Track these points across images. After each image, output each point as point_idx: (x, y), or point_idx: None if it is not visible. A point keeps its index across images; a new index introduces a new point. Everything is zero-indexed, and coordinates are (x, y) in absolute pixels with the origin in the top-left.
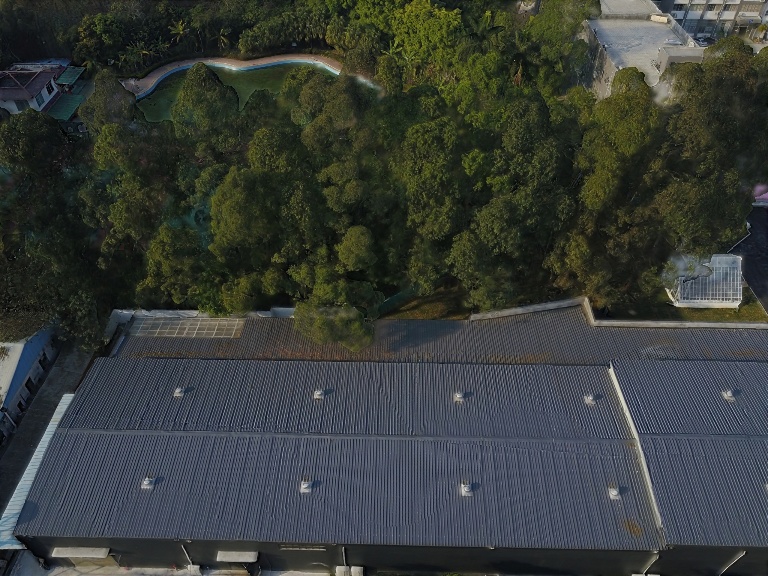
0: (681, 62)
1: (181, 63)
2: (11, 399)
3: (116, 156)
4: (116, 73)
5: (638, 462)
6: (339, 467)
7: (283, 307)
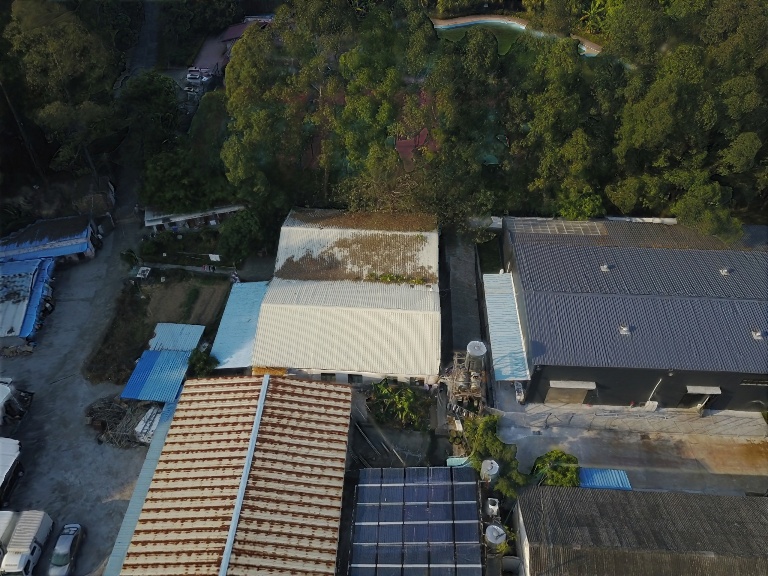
0: None
1: None
2: None
3: (571, 64)
4: None
5: None
6: None
7: (616, 217)
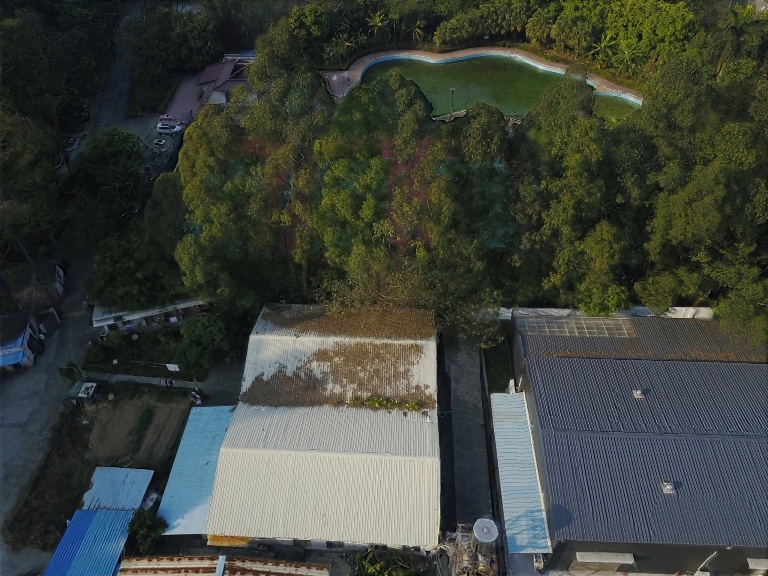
0: None
1: (377, 55)
2: None
3: (596, 151)
4: (320, 65)
5: None
6: None
7: (643, 306)
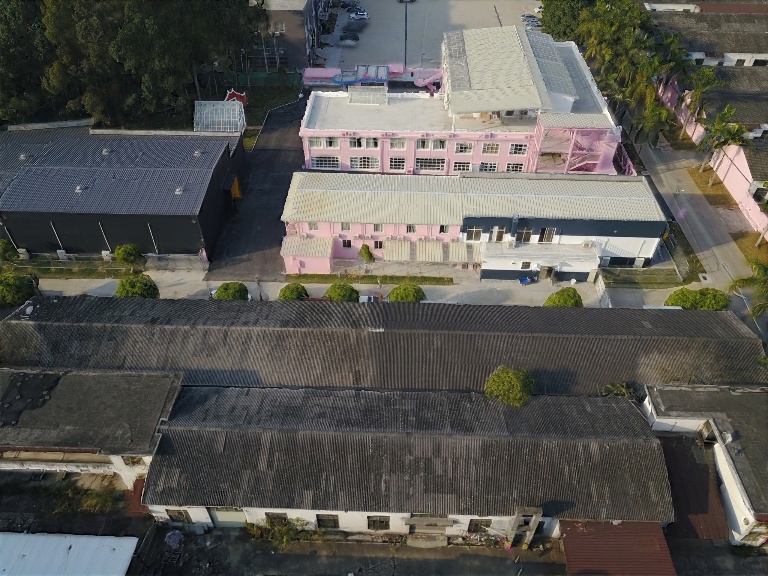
0: None
1: None
2: None
3: None
4: None
5: None
6: None
7: None
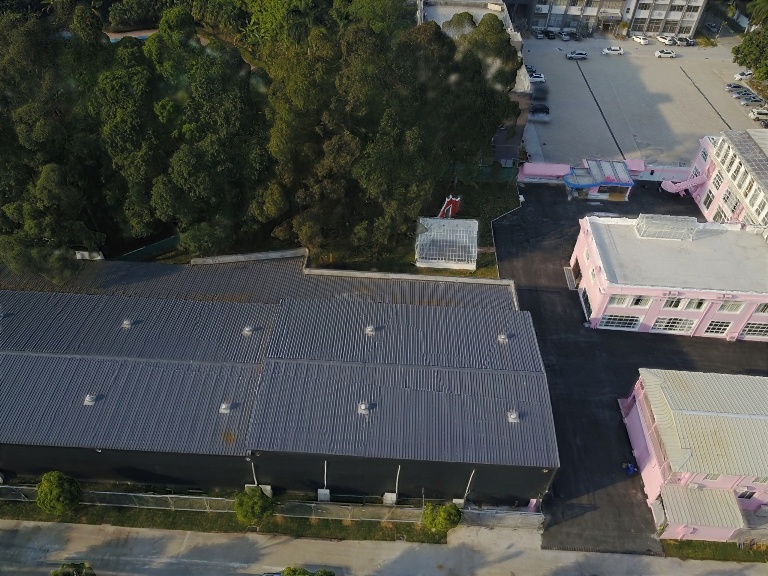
0: None
1: None
2: None
3: None
4: None
5: None
6: None
7: None
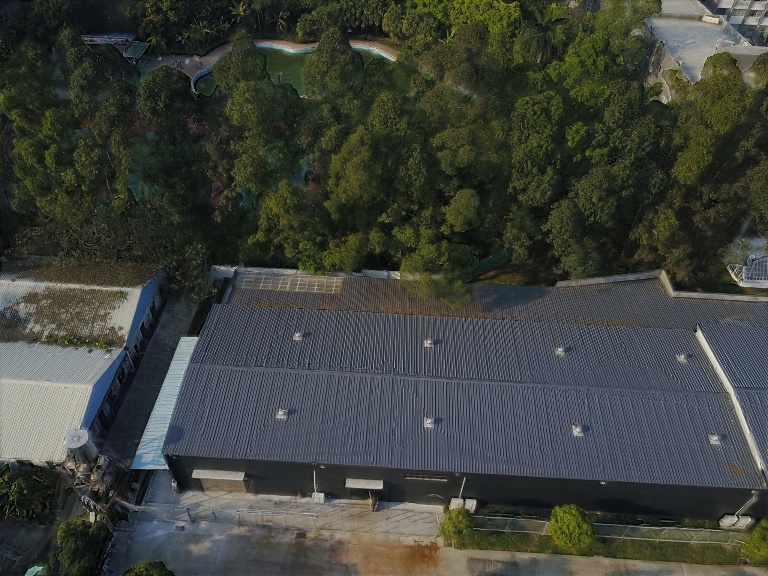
0: (738, 60)
1: None
2: (130, 340)
3: (253, 112)
4: (179, 50)
5: (733, 413)
6: (457, 406)
7: (373, 270)
